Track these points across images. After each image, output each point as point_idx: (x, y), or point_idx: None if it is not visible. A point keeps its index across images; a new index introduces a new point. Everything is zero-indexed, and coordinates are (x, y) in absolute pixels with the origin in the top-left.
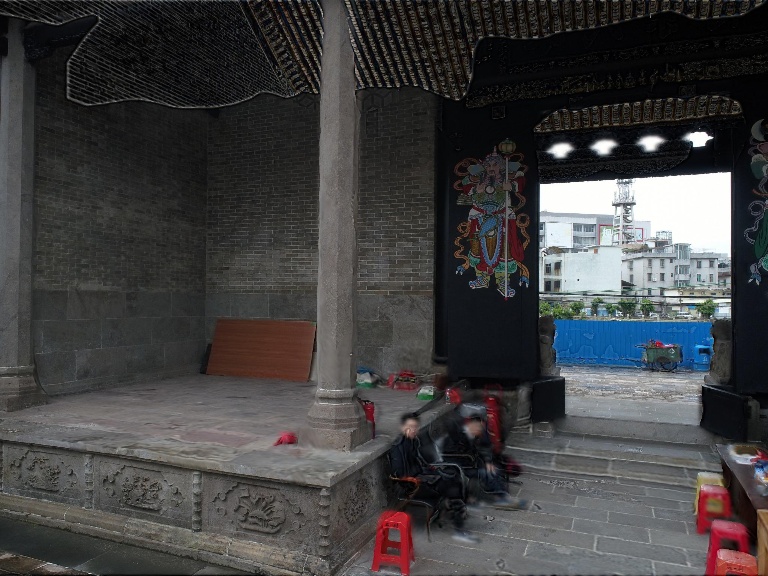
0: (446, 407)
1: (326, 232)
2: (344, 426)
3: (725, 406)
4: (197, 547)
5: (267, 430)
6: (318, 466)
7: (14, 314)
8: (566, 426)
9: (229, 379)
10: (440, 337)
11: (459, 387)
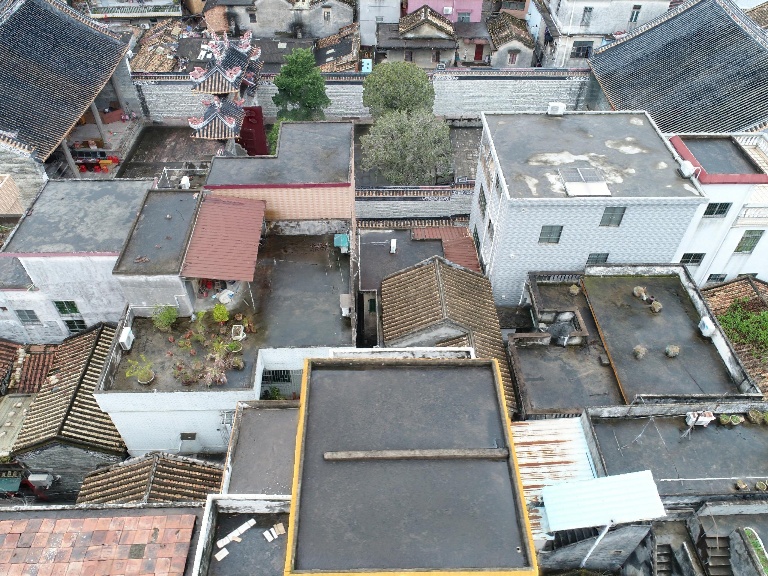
0: None
1: None
2: None
3: (51, 157)
4: None
5: None
6: None
7: None
8: None
9: None
10: None
11: None
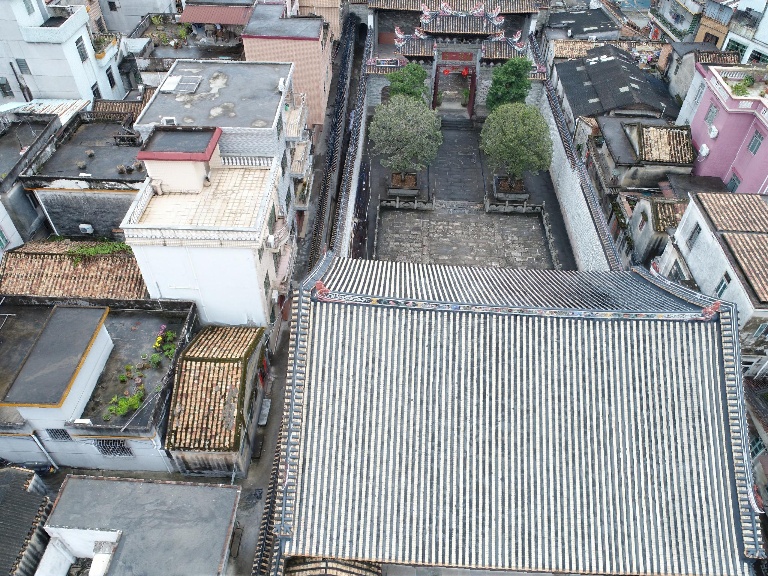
0: None
1: None
2: None
3: None
4: None
5: None
6: None
7: (377, 46)
8: None
9: None
10: None
11: None
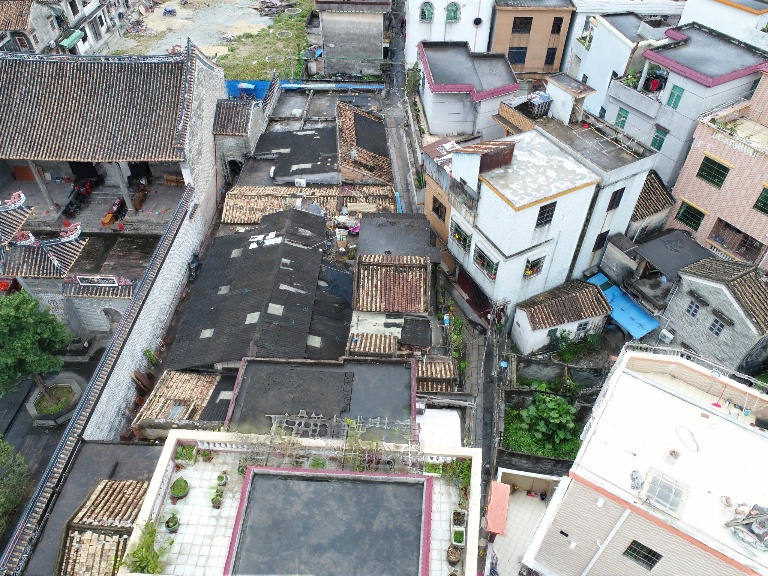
0: (76, 191)
1: (41, 188)
2: (55, 211)
3: None
4: (41, 229)
5: (43, 209)
6: (53, 218)
7: None
8: (105, 184)
9: (24, 183)
10: (73, 170)
11: (80, 181)
